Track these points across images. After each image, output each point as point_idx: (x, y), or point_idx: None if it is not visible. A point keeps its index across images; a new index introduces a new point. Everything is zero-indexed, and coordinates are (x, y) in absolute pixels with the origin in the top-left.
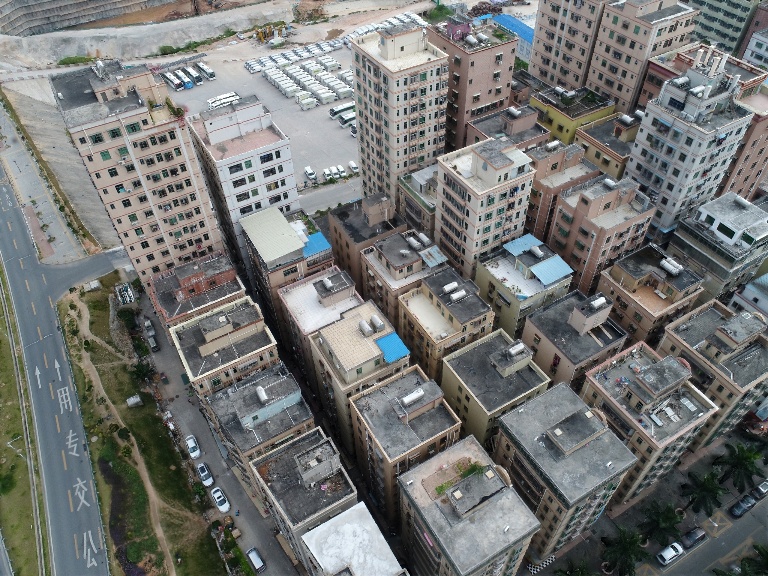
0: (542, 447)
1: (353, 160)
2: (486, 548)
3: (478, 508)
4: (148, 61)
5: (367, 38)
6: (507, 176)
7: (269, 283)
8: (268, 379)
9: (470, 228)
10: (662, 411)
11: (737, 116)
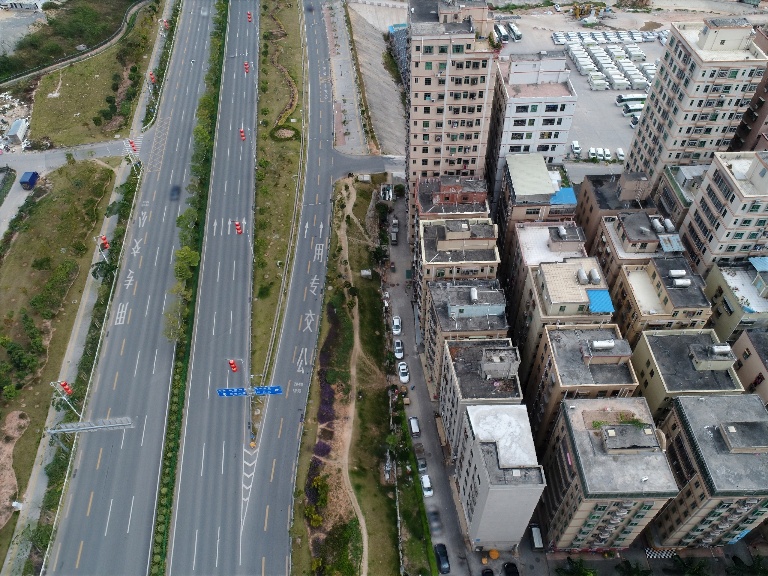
0: (709, 436)
1: (622, 148)
2: (619, 484)
3: (625, 453)
4: None
5: (690, 25)
6: None
7: (511, 215)
8: (481, 288)
9: (721, 229)
10: None
11: None
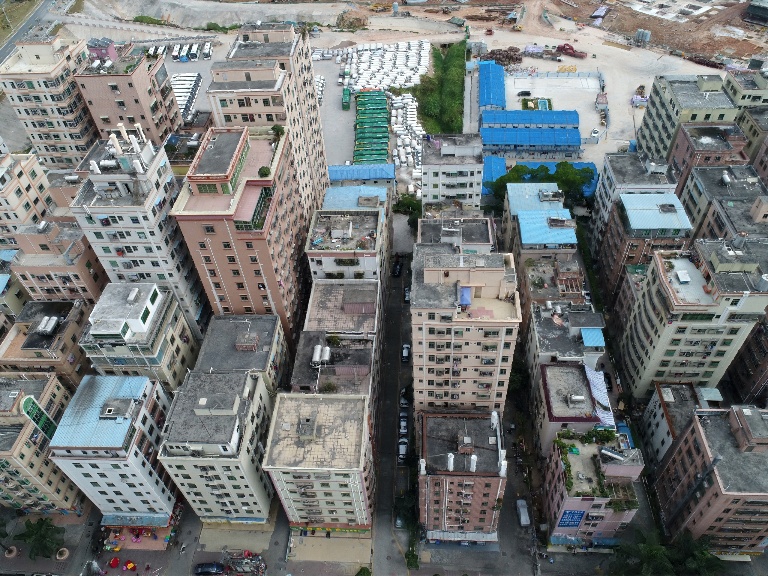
0: None
1: None
2: None
3: None
4: (181, 32)
5: None
6: None
7: None
8: None
9: None
10: None
11: None
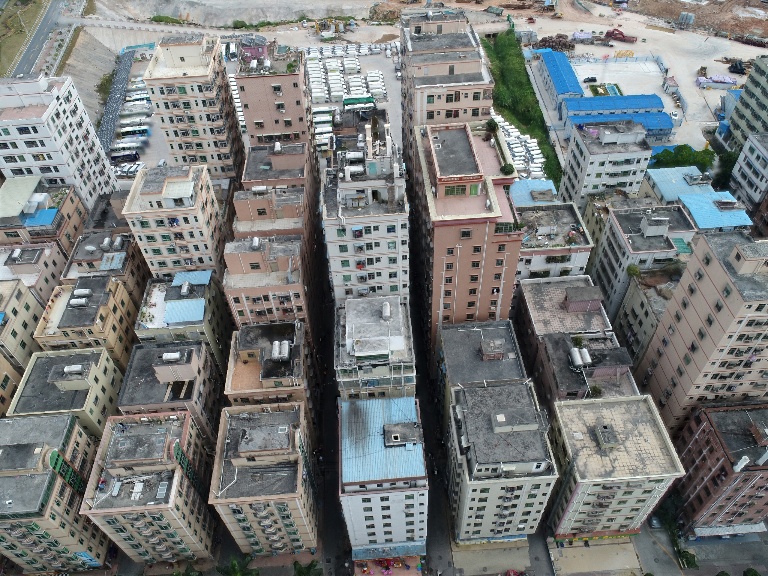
0: None
1: None
2: None
3: None
4: (211, 31)
5: None
6: (162, 204)
7: None
8: None
9: None
10: (131, 483)
11: (398, 211)
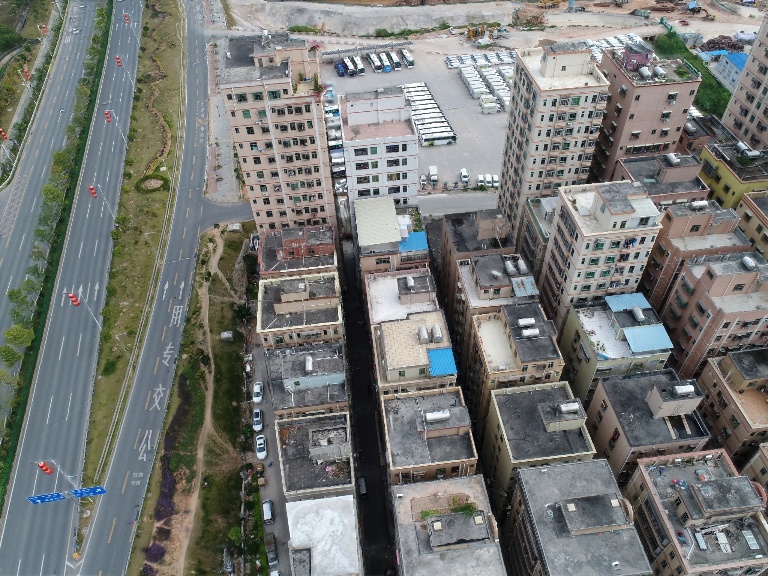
0: (549, 516)
1: None
2: None
3: (454, 548)
4: (361, 40)
5: (534, 51)
6: (625, 224)
7: (361, 266)
8: (325, 353)
9: (572, 268)
10: (712, 534)
11: None
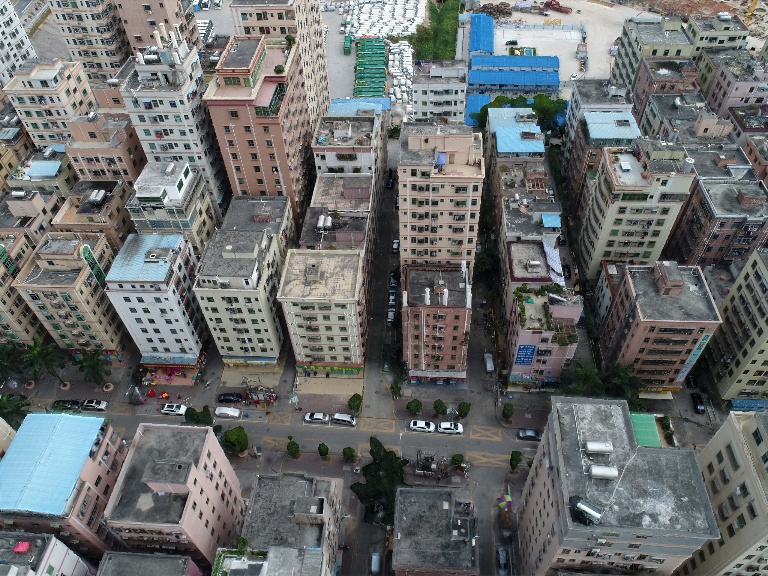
0: None
1: None
2: None
3: None
4: None
5: None
6: (32, 85)
7: None
8: None
9: None
10: None
11: None
